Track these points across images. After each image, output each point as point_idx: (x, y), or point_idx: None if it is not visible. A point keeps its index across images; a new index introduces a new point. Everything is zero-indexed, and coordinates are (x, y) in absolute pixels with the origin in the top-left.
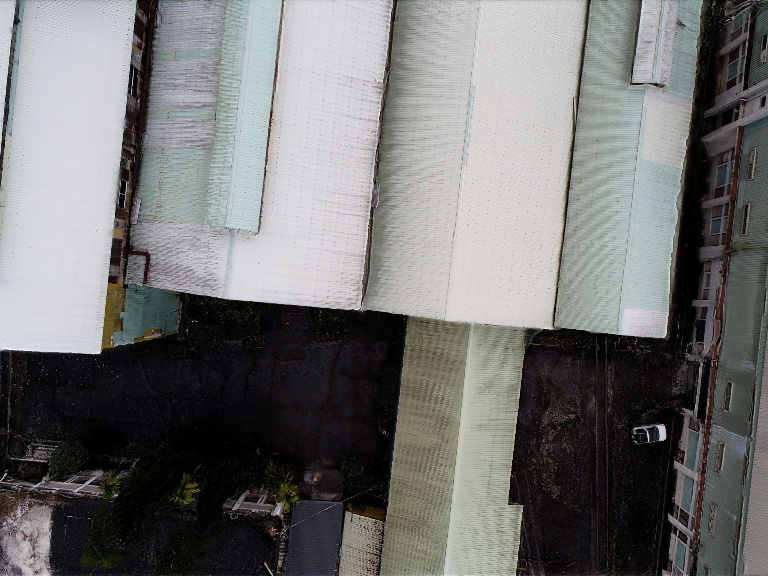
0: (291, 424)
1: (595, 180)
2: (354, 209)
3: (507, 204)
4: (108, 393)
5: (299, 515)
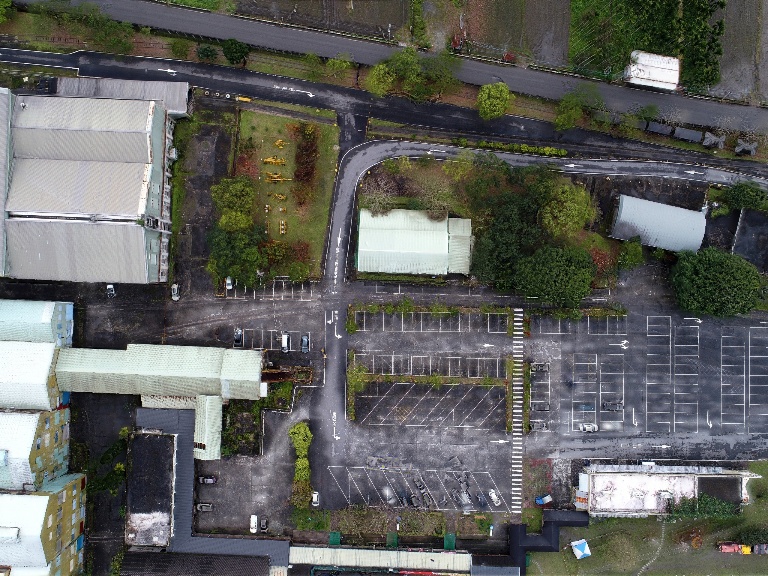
0: (119, 428)
1: (1, 333)
2: (6, 419)
3: (8, 365)
4: (111, 499)
5: (141, 425)
